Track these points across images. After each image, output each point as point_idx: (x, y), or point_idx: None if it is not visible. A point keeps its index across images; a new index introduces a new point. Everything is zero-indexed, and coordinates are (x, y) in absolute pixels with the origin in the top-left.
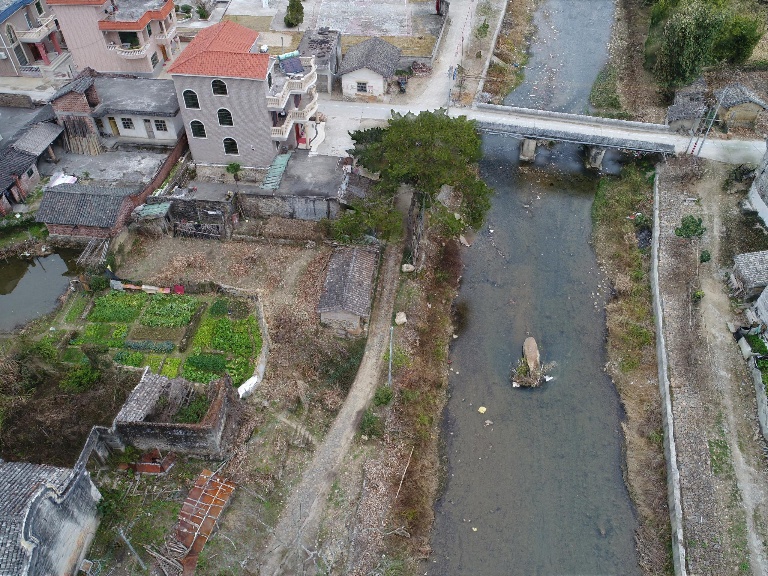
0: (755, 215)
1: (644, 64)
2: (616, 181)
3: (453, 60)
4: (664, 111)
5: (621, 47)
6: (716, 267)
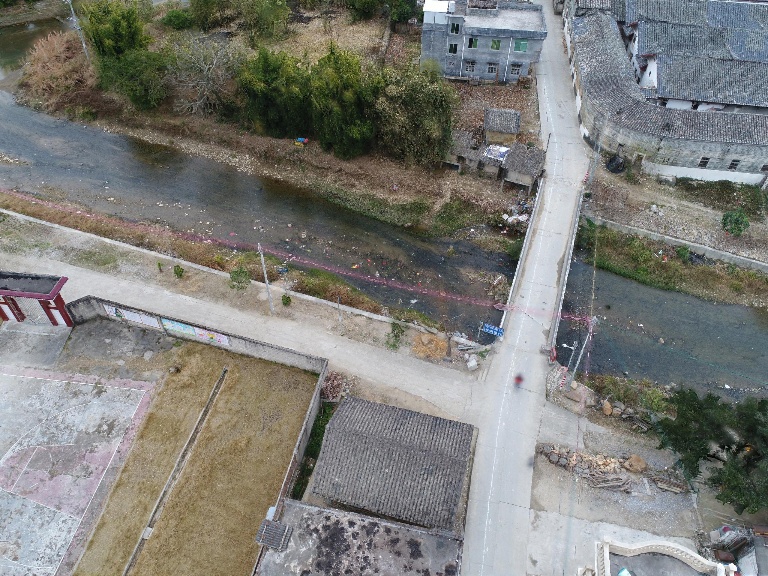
0: (677, 179)
1: (348, 157)
2: (591, 252)
3: (293, 337)
4: (452, 176)
5: (256, 163)
6: (764, 226)
